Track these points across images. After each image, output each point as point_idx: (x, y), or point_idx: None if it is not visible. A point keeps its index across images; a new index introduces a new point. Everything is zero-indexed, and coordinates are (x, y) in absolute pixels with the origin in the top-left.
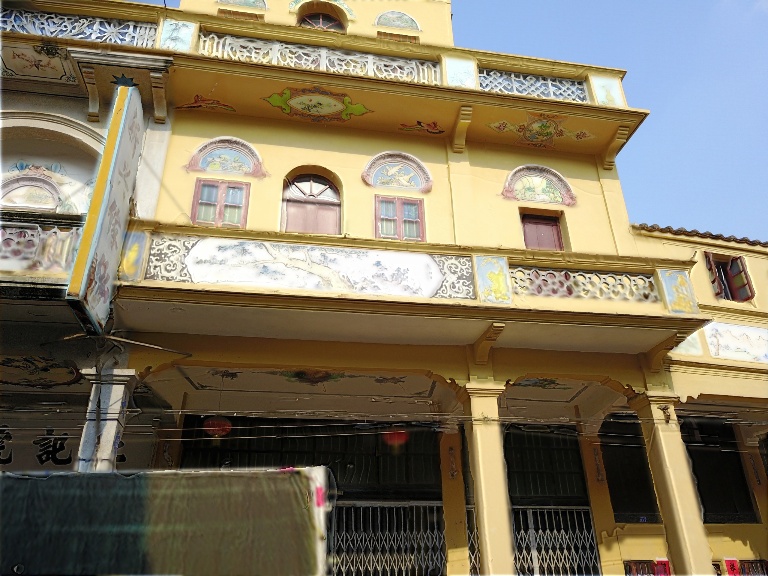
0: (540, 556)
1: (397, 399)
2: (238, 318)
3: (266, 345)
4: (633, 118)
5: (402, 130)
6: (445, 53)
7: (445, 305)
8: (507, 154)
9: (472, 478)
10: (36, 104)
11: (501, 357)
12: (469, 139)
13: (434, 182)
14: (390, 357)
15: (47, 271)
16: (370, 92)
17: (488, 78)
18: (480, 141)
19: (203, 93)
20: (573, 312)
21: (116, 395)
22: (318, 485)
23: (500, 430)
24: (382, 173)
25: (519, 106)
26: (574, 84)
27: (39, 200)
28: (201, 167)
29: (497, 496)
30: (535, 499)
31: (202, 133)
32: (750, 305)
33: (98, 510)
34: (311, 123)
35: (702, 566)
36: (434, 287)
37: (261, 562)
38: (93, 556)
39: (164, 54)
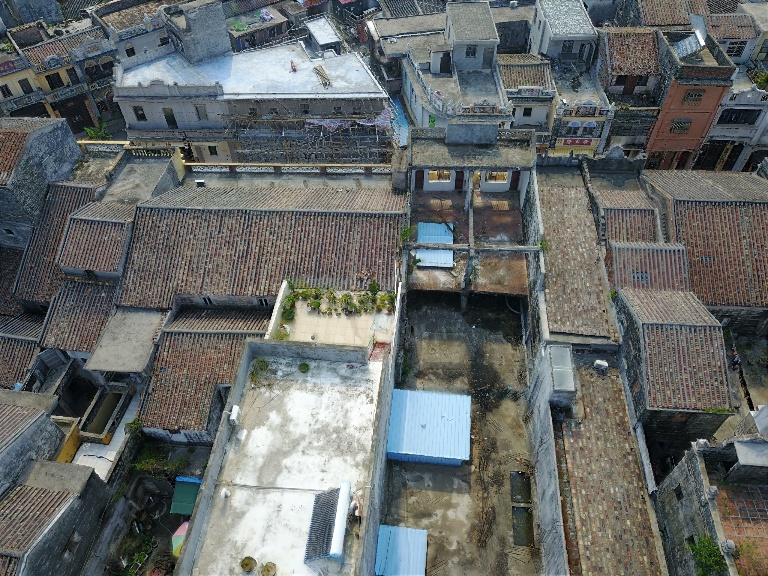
0: None
1: None
2: None
3: None
4: None
5: None
6: None
7: None
8: None
9: None
10: None
11: None
12: None
13: None
14: None
15: None
16: None
17: None
18: None
19: None
20: None
21: None
22: None
23: None
24: None
25: None
26: None
27: None
28: None
29: None
30: None
31: None
32: None
33: None
34: None
35: None
36: None
37: None
38: None
39: None
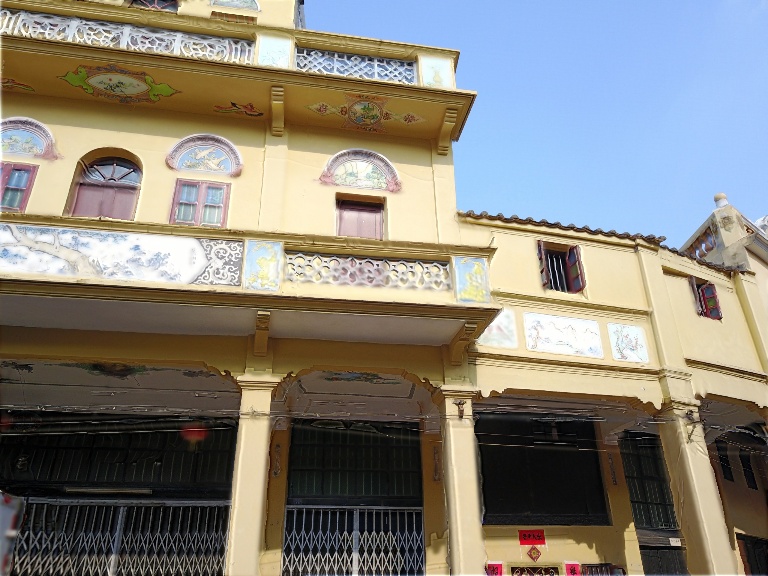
0: (361, 559)
1: (223, 394)
2: None
3: (22, 334)
4: (460, 100)
5: (217, 112)
6: (260, 31)
7: (199, 291)
8: (332, 138)
9: (298, 477)
10: None
11: (284, 348)
12: (288, 122)
13: (245, 166)
14: (160, 348)
15: None
16: (171, 71)
17: (308, 58)
18: (301, 124)
19: None
20: (345, 300)
21: None
22: None
23: (269, 425)
24: (190, 156)
25: (334, 87)
26: (403, 65)
27: None
28: None
29: (252, 495)
30: (366, 499)
31: None
32: (581, 296)
33: None
34: (119, 104)
35: (473, 570)
36: (195, 273)
37: None
38: None
39: None
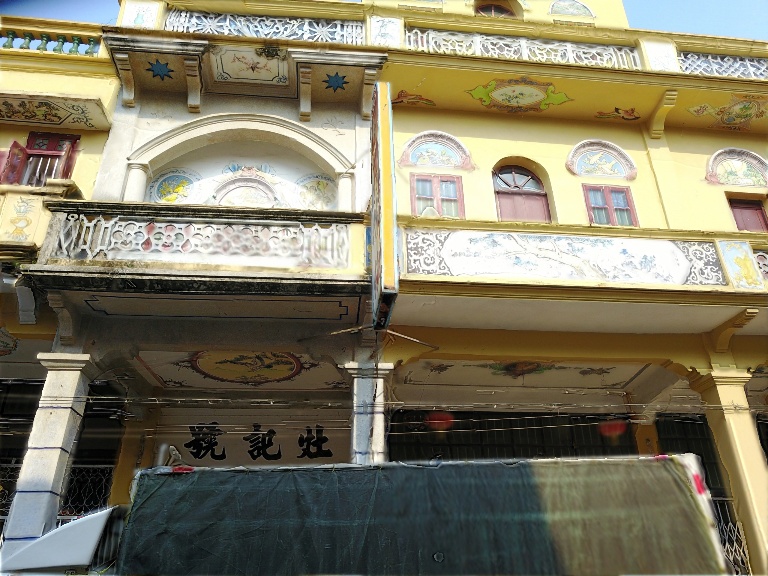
0: None
1: (589, 391)
2: (492, 310)
3: (508, 337)
4: None
5: (598, 118)
6: (643, 37)
7: (702, 292)
8: (704, 138)
9: None
10: (248, 106)
11: (739, 344)
12: (667, 124)
13: (638, 169)
14: (629, 346)
15: (319, 267)
16: (576, 80)
17: (686, 61)
18: (677, 126)
19: (408, 88)
20: None
21: (377, 389)
22: (694, 472)
23: (752, 419)
24: (584, 162)
25: (725, 88)
26: None
27: (255, 200)
28: (412, 162)
29: (763, 486)
30: None
31: (407, 128)
32: None
33: (496, 498)
34: (507, 114)
35: None
36: (683, 274)
37: (664, 550)
38: (504, 544)
39: (379, 51)
